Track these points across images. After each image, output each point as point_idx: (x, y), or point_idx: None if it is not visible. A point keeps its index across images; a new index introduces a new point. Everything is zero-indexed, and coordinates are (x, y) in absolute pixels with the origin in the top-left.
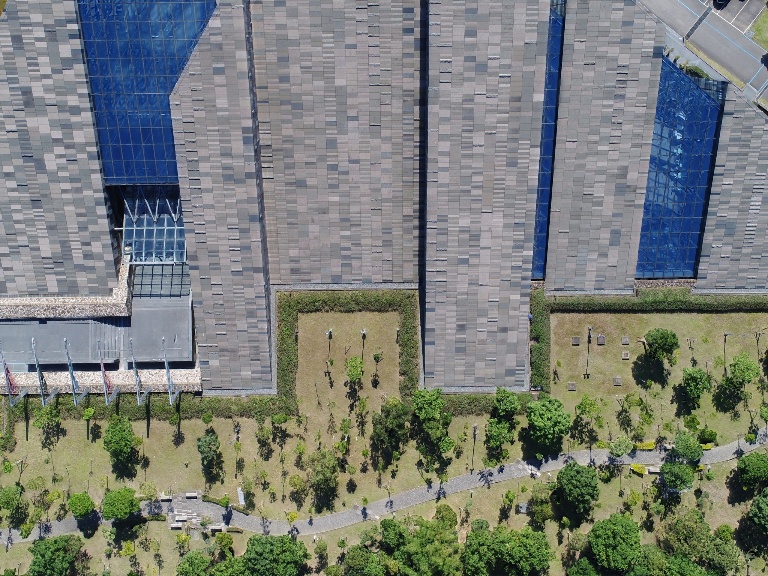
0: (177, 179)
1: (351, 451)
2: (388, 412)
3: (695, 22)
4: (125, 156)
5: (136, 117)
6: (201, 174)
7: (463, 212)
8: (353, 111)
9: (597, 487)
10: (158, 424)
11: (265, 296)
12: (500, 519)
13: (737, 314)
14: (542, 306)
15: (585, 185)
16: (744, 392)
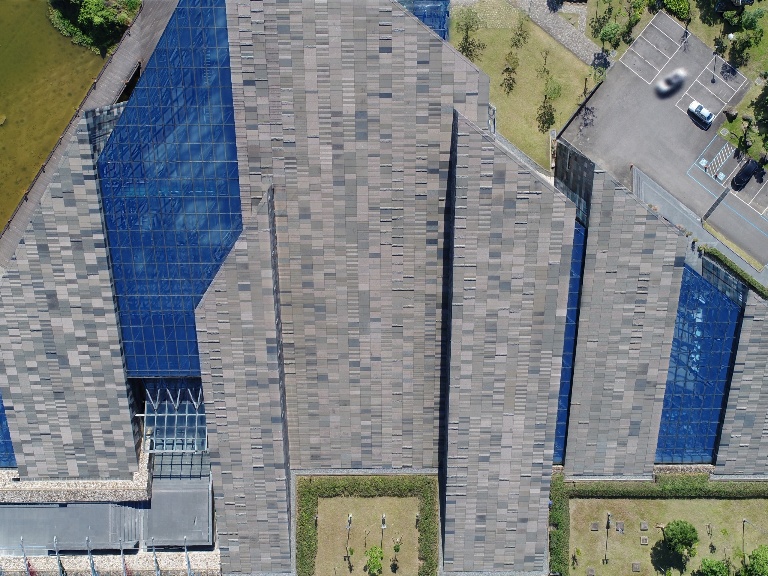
0: (199, 372)
1: None
2: None
3: (713, 203)
4: (148, 351)
5: (160, 316)
6: (225, 380)
7: (485, 414)
8: (376, 313)
9: None
10: None
11: (286, 488)
12: None
13: (755, 500)
14: (561, 493)
15: (605, 381)
16: None
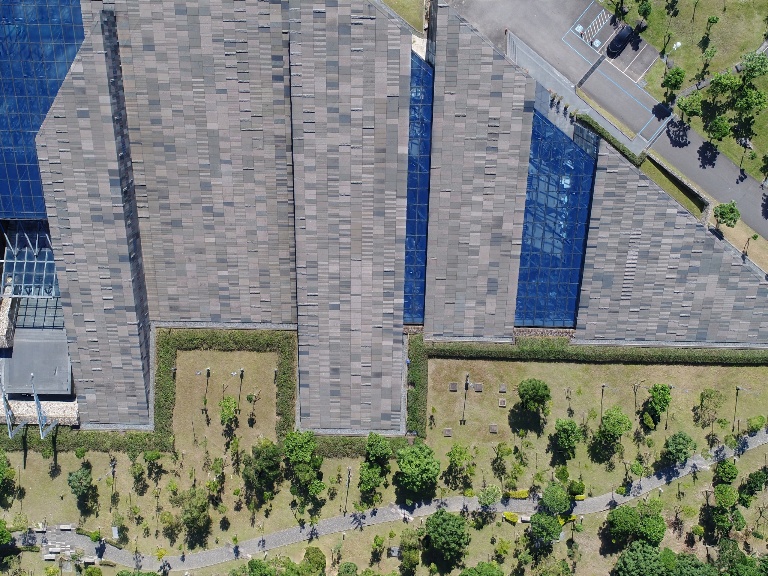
0: None
1: (226, 489)
2: (259, 453)
3: (588, 70)
4: (2, 191)
5: (12, 153)
6: (70, 214)
7: (332, 259)
8: (226, 155)
9: (465, 535)
10: (35, 456)
11: (139, 334)
12: (371, 562)
13: (616, 365)
14: (419, 351)
15: (460, 234)
16: (616, 445)
